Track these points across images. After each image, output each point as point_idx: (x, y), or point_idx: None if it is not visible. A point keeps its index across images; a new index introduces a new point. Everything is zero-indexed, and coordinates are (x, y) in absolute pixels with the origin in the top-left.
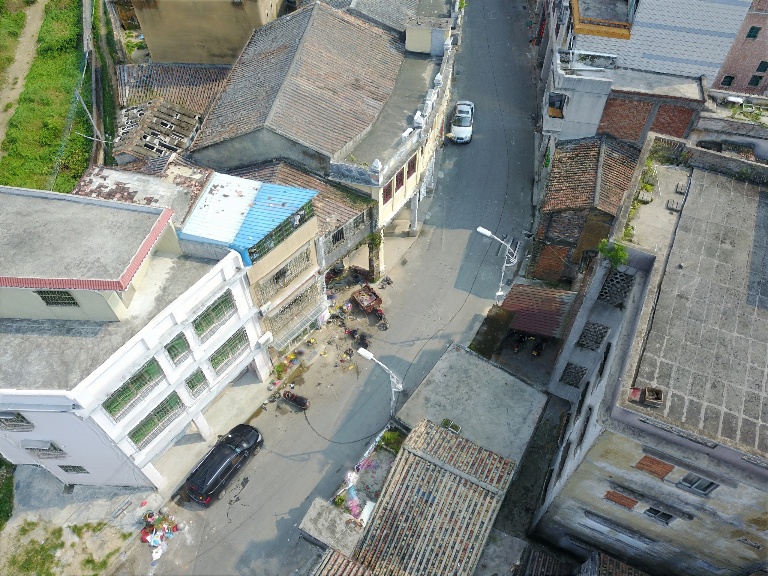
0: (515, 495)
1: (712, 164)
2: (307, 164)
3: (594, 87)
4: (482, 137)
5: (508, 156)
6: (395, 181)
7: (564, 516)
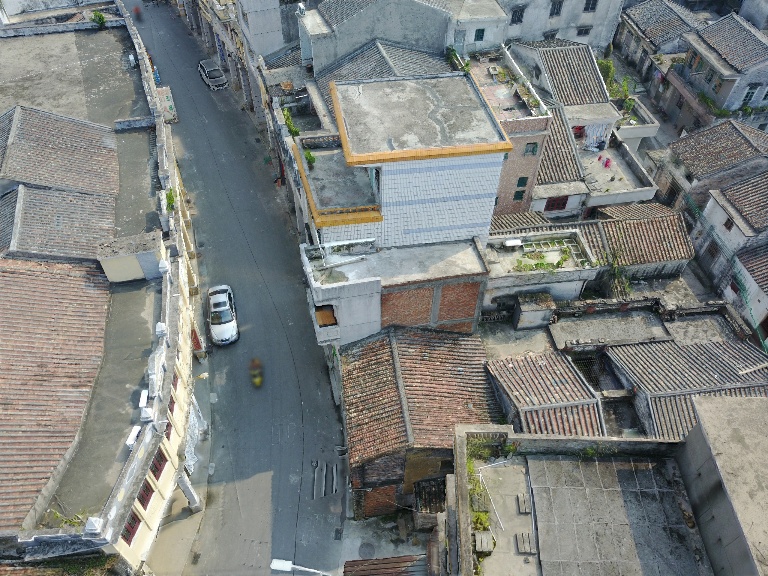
0: None
1: (547, 447)
2: None
3: (361, 289)
4: (252, 326)
5: (289, 344)
6: (138, 502)
7: None
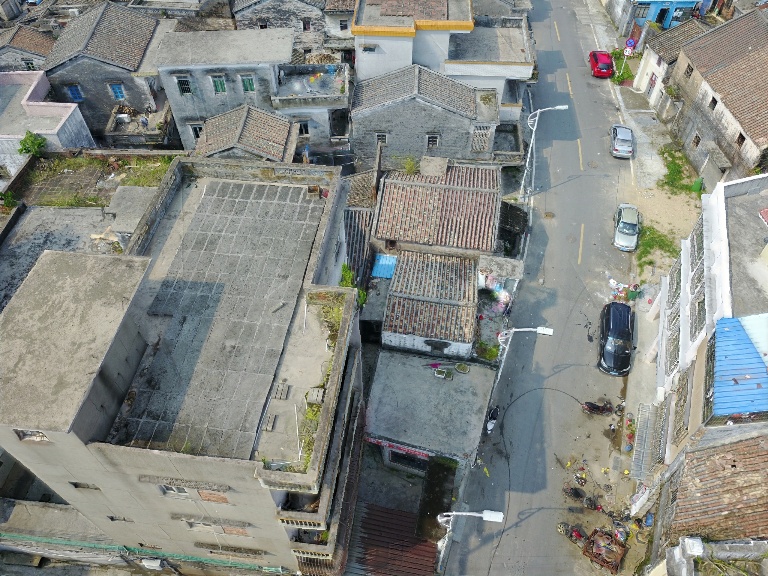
0: None
1: None
2: None
3: None
4: None
5: None
6: None
7: None
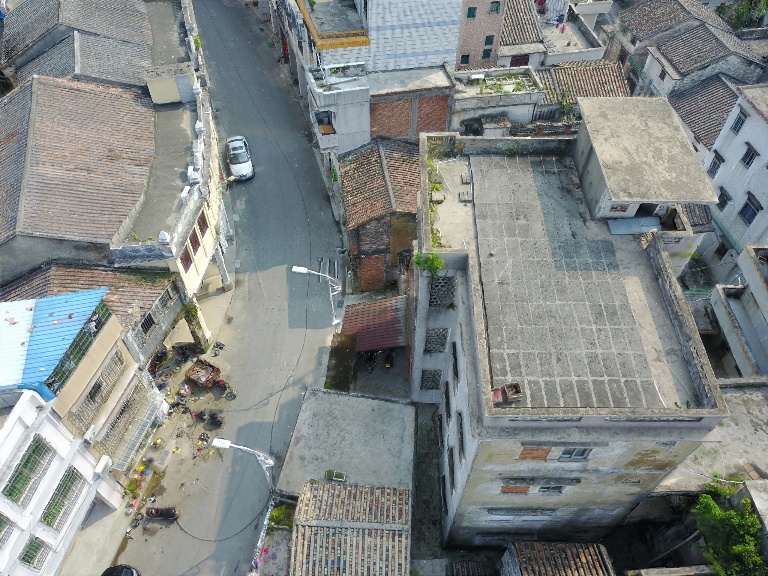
0: (418, 513)
1: (483, 148)
2: (84, 258)
3: (354, 97)
4: (264, 168)
5: (296, 180)
6: (190, 245)
7: (470, 520)
